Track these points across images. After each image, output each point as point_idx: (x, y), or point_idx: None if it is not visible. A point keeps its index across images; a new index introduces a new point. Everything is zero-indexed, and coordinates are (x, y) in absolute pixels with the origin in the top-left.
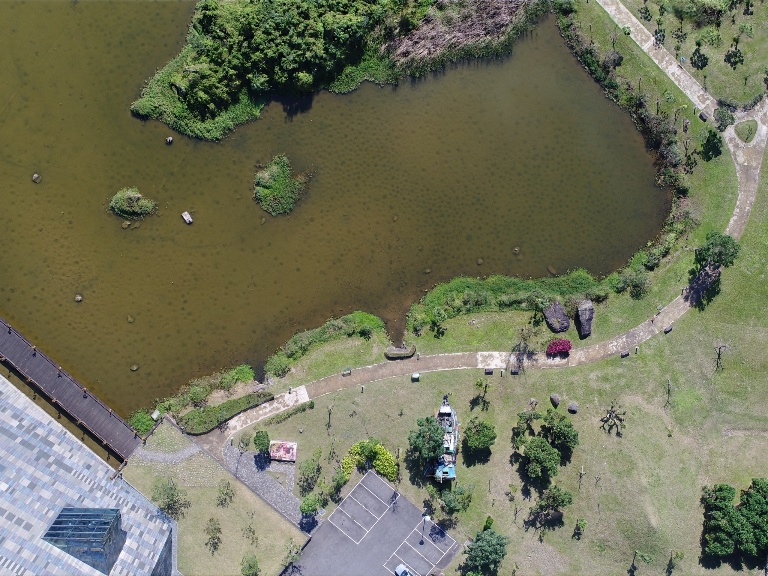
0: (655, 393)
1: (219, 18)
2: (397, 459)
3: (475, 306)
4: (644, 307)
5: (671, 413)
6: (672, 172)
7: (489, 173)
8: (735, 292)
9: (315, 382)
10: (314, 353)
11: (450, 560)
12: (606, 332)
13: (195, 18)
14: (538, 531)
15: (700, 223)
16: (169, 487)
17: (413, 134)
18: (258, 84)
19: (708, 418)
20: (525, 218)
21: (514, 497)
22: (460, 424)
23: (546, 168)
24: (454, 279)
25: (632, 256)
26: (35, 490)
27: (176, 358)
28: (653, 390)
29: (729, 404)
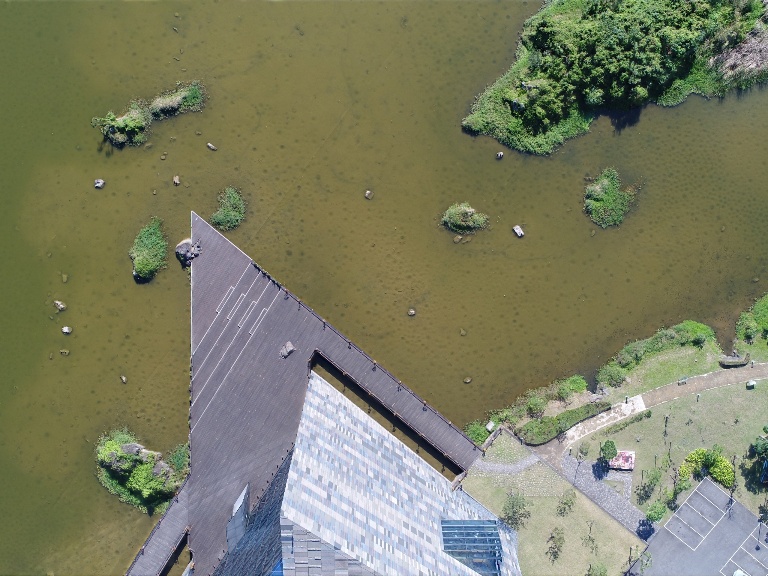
0: None
1: (557, 34)
2: None
3: None
4: None
5: None
6: None
7: None
8: None
9: (651, 391)
10: (648, 363)
11: None
12: None
13: (526, 35)
14: None
15: None
16: (521, 498)
17: (739, 145)
18: (595, 99)
19: None
20: None
21: None
22: None
23: None
24: None
25: None
26: (414, 503)
27: (508, 370)
28: None
29: None
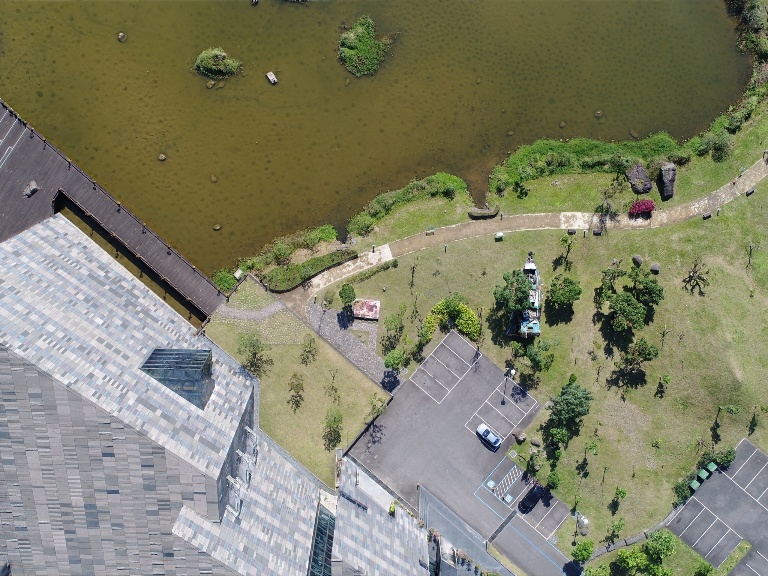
0: (737, 255)
1: None
2: None
3: (558, 167)
4: (726, 170)
5: (752, 275)
6: (754, 37)
7: (572, 37)
8: None
9: (399, 241)
10: (397, 213)
11: (531, 420)
12: (688, 194)
13: None
14: (621, 390)
15: None
16: (255, 339)
17: None
18: None
19: None
20: (607, 82)
21: (597, 356)
22: (543, 284)
23: (629, 32)
24: (537, 141)
25: (713, 120)
26: (128, 330)
27: (259, 218)
28: (735, 252)
29: None
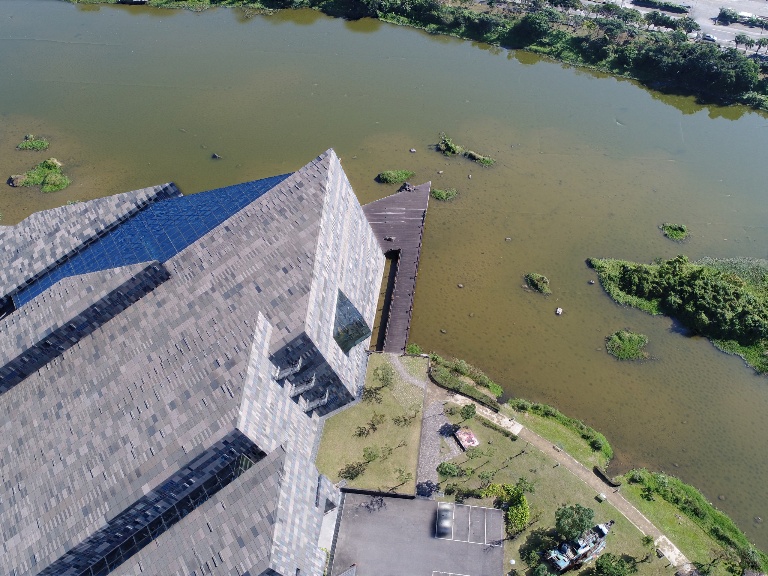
0: None
1: (683, 264)
2: None
3: (691, 511)
4: None
5: None
6: None
7: None
8: None
9: (532, 432)
10: (550, 421)
11: None
12: None
13: None
14: None
15: None
16: None
17: (745, 401)
18: (673, 299)
19: None
20: None
21: None
22: None
23: None
24: (691, 486)
25: None
26: None
27: (470, 349)
28: None
29: None
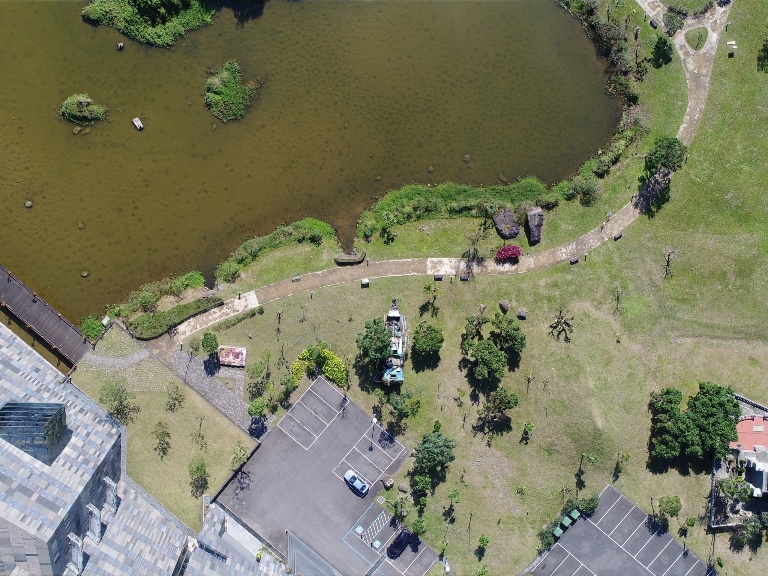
0: (604, 300)
1: None
2: (346, 364)
3: (425, 213)
4: (594, 214)
5: (620, 320)
6: (623, 80)
7: (440, 80)
8: (684, 199)
9: (265, 287)
10: (264, 259)
11: (399, 466)
12: (556, 239)
13: None
14: (486, 436)
15: (650, 130)
16: (116, 388)
17: (364, 41)
18: None
19: (657, 325)
20: (476, 126)
21: (463, 402)
22: (409, 330)
23: (497, 76)
24: (405, 186)
25: (582, 164)
26: None
27: (126, 264)
28: (602, 297)
29: (678, 311)
